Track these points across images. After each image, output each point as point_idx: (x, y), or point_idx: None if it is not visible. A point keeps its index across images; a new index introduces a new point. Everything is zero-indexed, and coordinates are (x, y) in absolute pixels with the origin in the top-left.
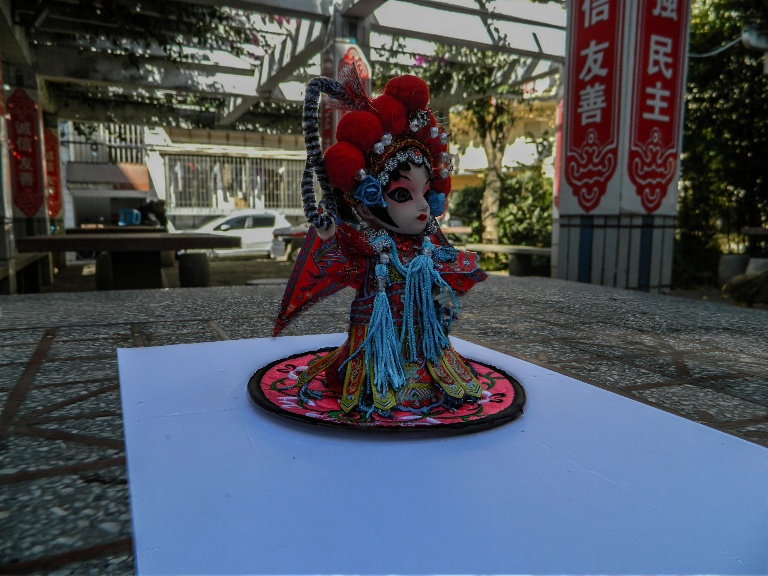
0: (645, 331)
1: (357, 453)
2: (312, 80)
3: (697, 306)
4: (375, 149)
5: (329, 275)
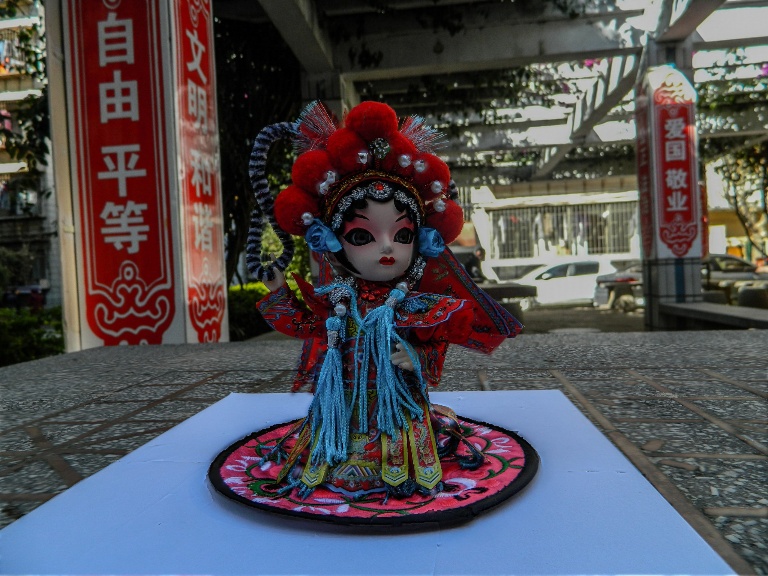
0: None
1: (217, 532)
2: None
3: None
4: (320, 189)
5: (281, 329)
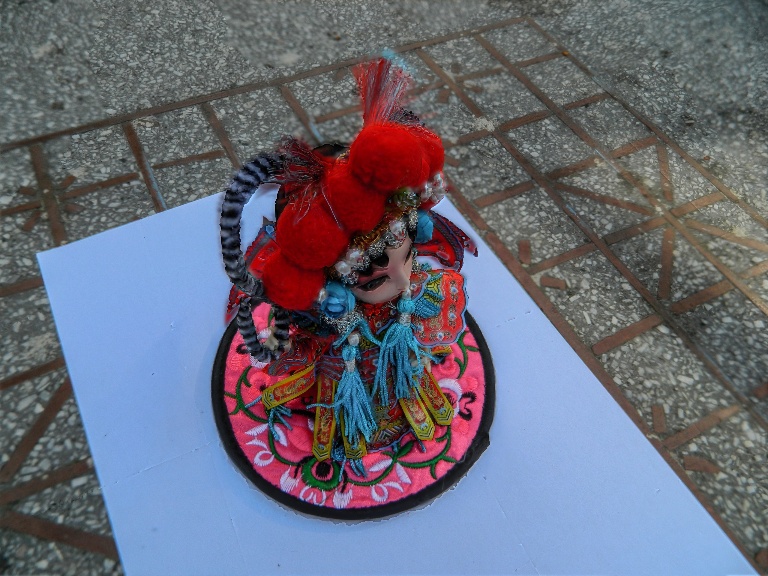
0: (653, 131)
1: (334, 549)
2: (225, 202)
3: (736, 12)
4: (338, 270)
5: None
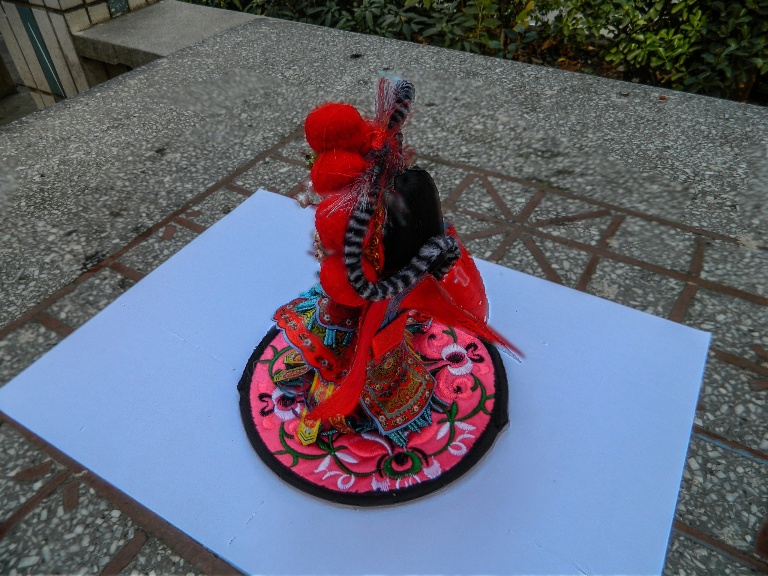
0: None
1: None
2: None
3: None
4: None
5: None
